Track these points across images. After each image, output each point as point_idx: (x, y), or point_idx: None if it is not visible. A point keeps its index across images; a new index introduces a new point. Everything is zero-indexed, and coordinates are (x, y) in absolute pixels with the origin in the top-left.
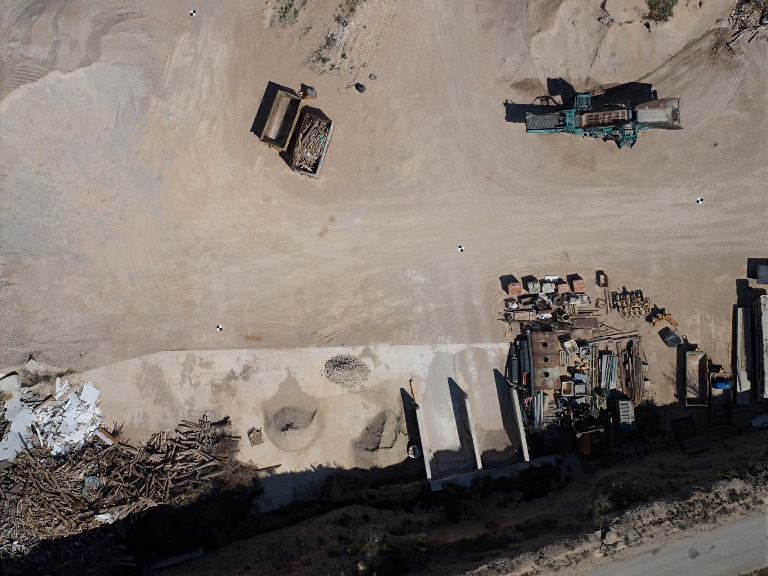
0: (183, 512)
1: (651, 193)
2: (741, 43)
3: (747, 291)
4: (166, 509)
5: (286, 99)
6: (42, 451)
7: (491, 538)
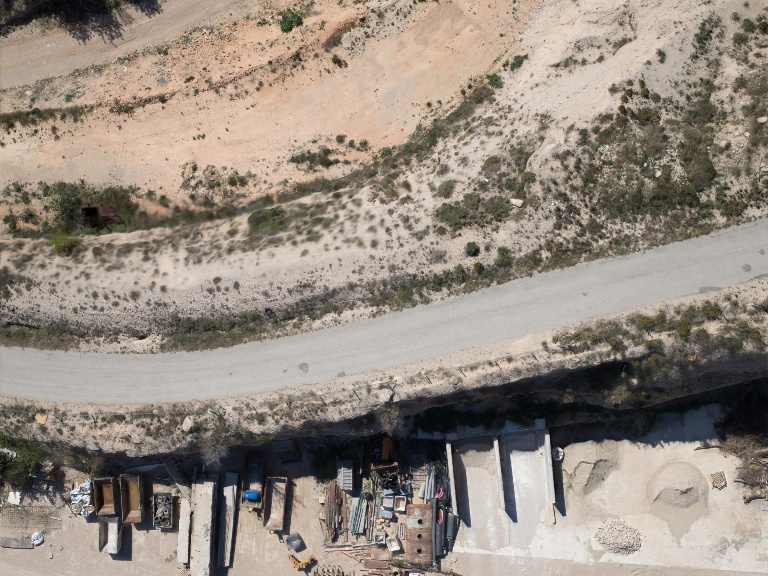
0: None
1: None
2: None
3: None
4: None
5: None
6: None
7: (499, 393)
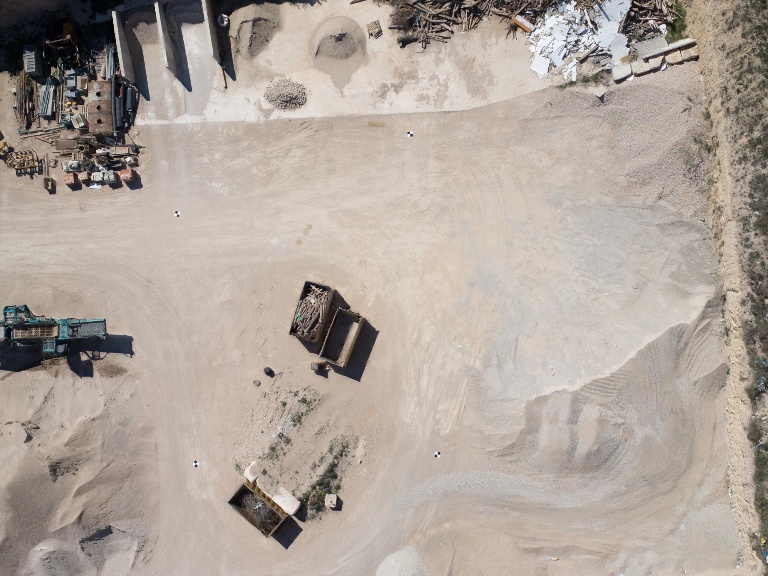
0: None
1: (5, 266)
2: None
3: None
4: None
5: None
6: (585, 4)
7: None
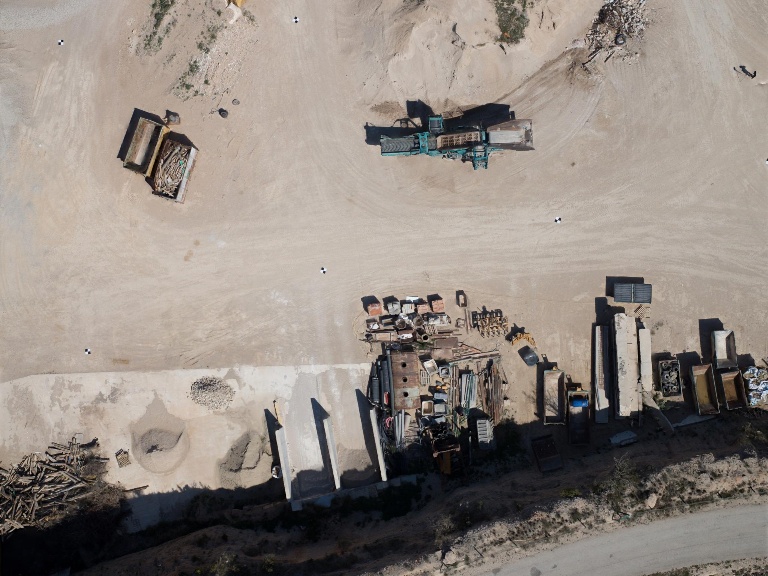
0: (48, 534)
1: (510, 213)
2: (598, 63)
3: (605, 309)
4: (32, 531)
5: (151, 125)
6: None
7: (338, 558)
